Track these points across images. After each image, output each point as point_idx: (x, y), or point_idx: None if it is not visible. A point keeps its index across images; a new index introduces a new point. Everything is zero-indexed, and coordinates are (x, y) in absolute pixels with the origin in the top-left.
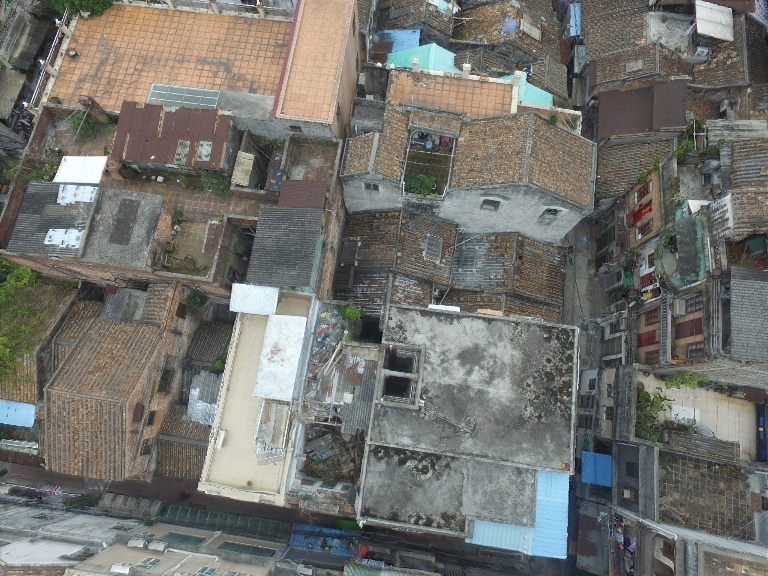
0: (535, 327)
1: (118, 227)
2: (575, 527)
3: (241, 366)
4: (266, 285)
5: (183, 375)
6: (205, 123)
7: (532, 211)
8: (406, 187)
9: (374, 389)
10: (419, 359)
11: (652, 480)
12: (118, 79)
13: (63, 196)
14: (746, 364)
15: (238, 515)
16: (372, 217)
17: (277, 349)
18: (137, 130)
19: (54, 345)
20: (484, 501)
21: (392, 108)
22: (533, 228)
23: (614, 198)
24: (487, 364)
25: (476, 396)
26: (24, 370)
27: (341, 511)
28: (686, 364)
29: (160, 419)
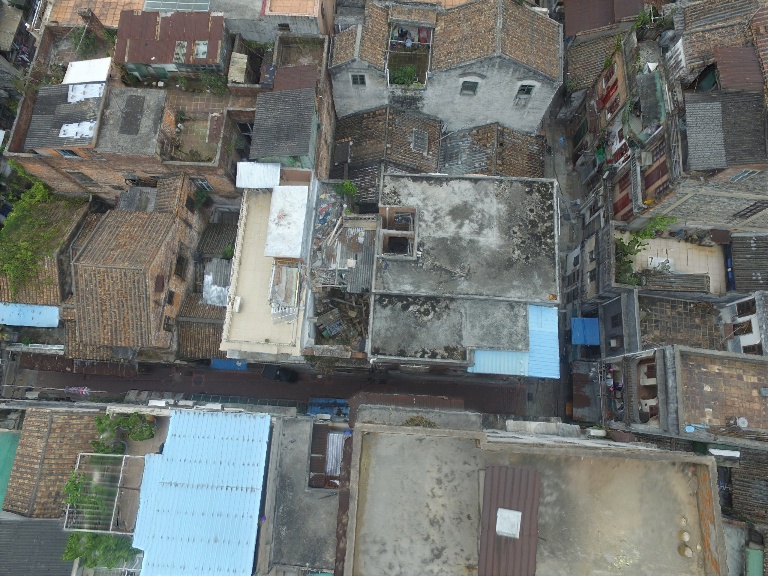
0: (517, 183)
1: (127, 119)
2: (570, 389)
3: (250, 243)
4: (268, 162)
5: (196, 268)
6: (199, 24)
7: (508, 91)
8: (390, 79)
9: (375, 246)
10: (414, 220)
11: (634, 318)
12: (112, 2)
13: (73, 95)
14: (705, 181)
15: (257, 398)
16: (361, 118)
17: (283, 214)
18: (136, 35)
19: (72, 251)
20: (482, 334)
21: (372, 3)
22: (511, 114)
23: (584, 90)
24: (476, 218)
25: (468, 245)
26: (46, 273)
27: (353, 363)
28: (655, 202)
29: (178, 303)
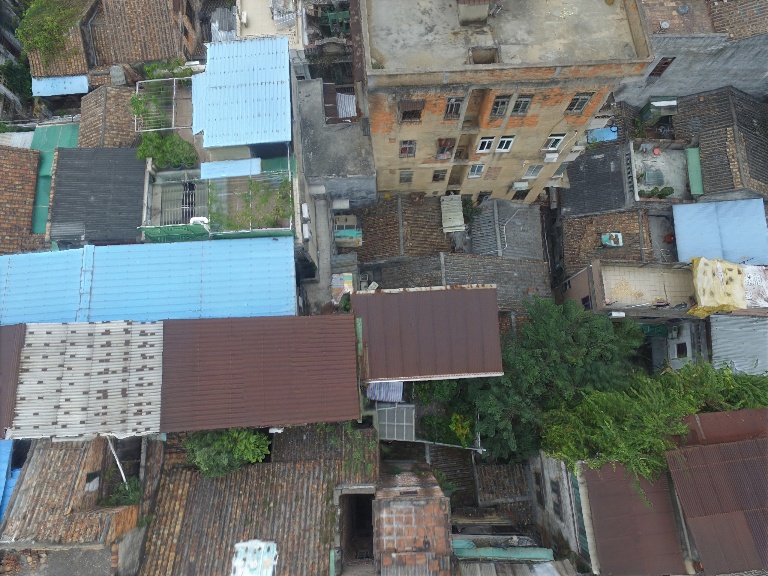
0: None
1: None
2: None
3: None
4: None
5: (202, 29)
6: None
7: None
8: None
9: None
10: None
11: None
12: None
13: None
14: None
15: None
16: None
17: None
18: None
19: (91, 27)
20: None
21: None
22: None
23: None
24: None
25: None
26: (71, 44)
27: (349, 59)
28: None
29: (192, 45)
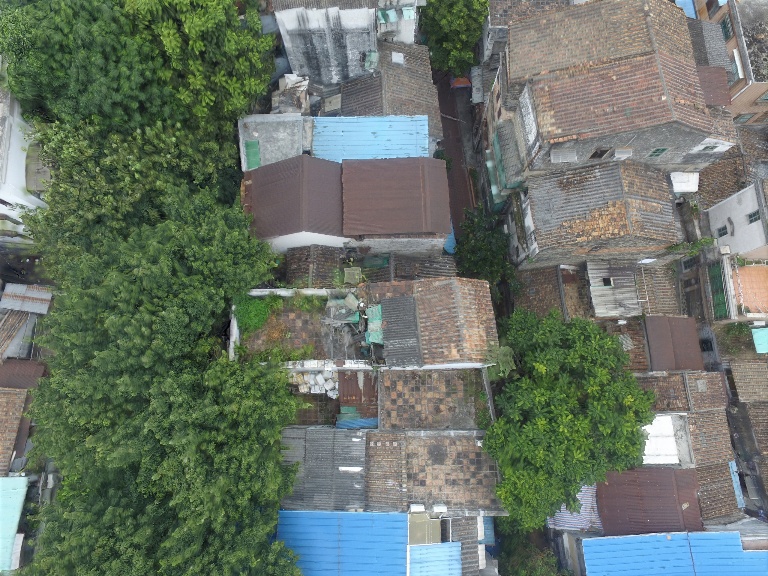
0: None
1: None
2: None
3: None
4: None
5: None
6: None
7: None
8: None
9: None
10: None
11: None
12: None
13: None
14: None
15: None
16: None
17: None
18: None
19: None
20: None
21: None
22: None
23: None
24: None
25: None
26: None
27: None
28: None
29: None
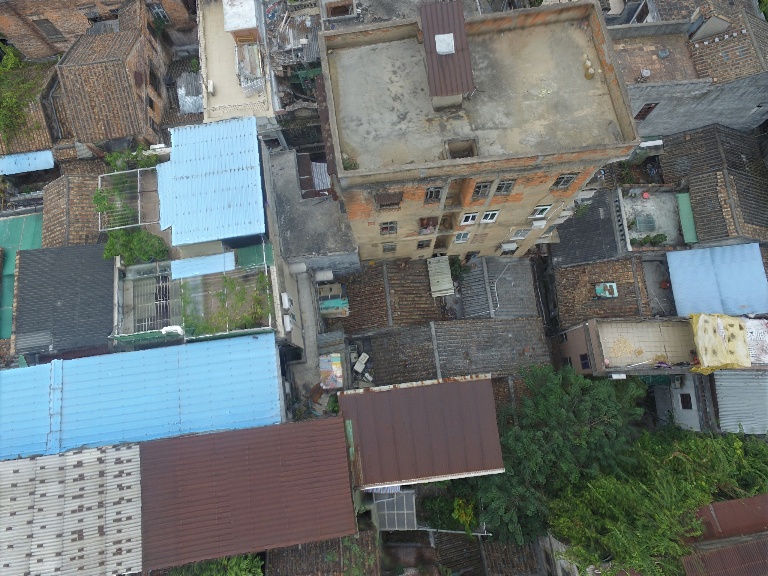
0: None
1: None
2: None
3: (212, 42)
4: None
5: (168, 93)
6: None
7: None
8: None
9: (320, 12)
10: None
11: None
12: None
13: None
14: None
15: None
16: None
17: None
18: None
19: (52, 99)
20: None
21: None
22: None
23: None
24: None
25: None
26: (33, 119)
27: None
28: None
29: (159, 114)
